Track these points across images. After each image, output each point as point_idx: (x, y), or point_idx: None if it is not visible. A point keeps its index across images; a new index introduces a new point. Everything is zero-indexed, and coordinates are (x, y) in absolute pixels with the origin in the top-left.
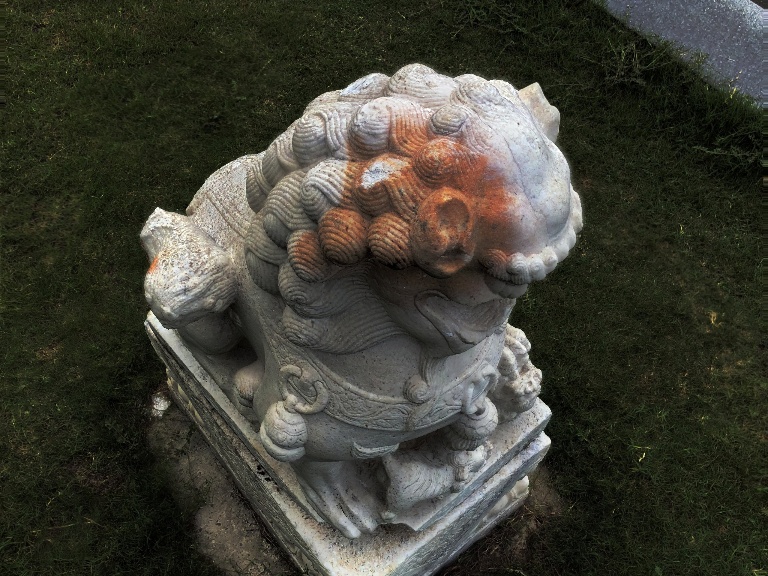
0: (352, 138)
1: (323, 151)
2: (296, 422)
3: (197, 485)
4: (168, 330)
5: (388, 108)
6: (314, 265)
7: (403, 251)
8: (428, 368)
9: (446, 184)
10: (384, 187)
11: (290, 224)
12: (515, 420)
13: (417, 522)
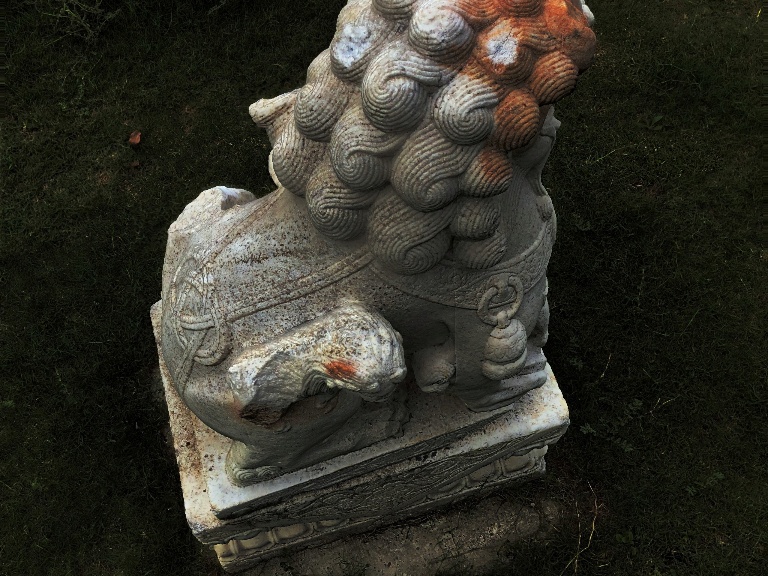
0: (443, 57)
1: (425, 95)
2: (517, 326)
3: (340, 575)
4: (246, 491)
5: (442, 8)
6: (508, 168)
7: (574, 70)
8: (540, 184)
9: (542, 2)
10: (523, 46)
11: (460, 169)
12: None
13: None
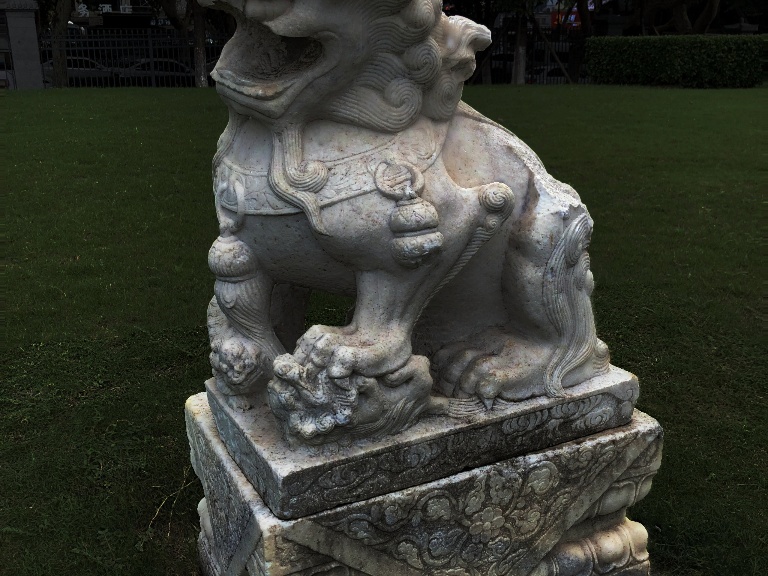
0: None
1: None
2: None
3: None
4: None
5: None
6: None
7: None
8: None
9: None
10: None
11: None
12: (282, 443)
13: (212, 381)
